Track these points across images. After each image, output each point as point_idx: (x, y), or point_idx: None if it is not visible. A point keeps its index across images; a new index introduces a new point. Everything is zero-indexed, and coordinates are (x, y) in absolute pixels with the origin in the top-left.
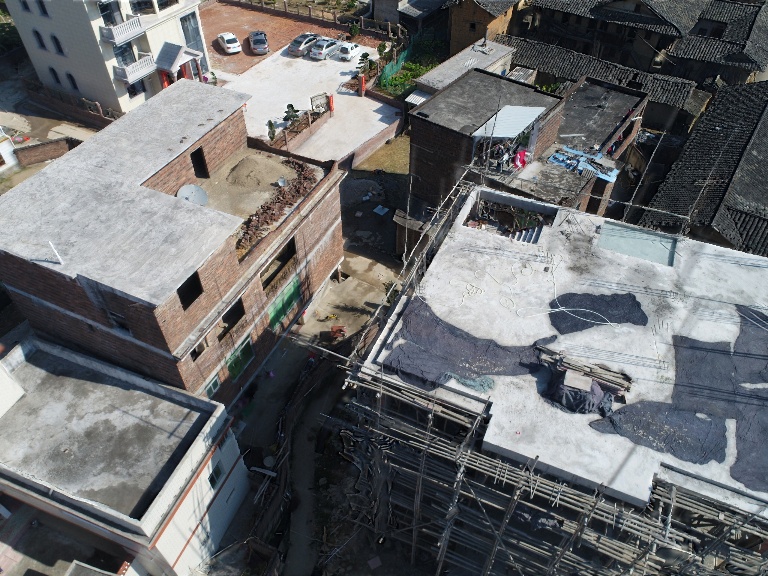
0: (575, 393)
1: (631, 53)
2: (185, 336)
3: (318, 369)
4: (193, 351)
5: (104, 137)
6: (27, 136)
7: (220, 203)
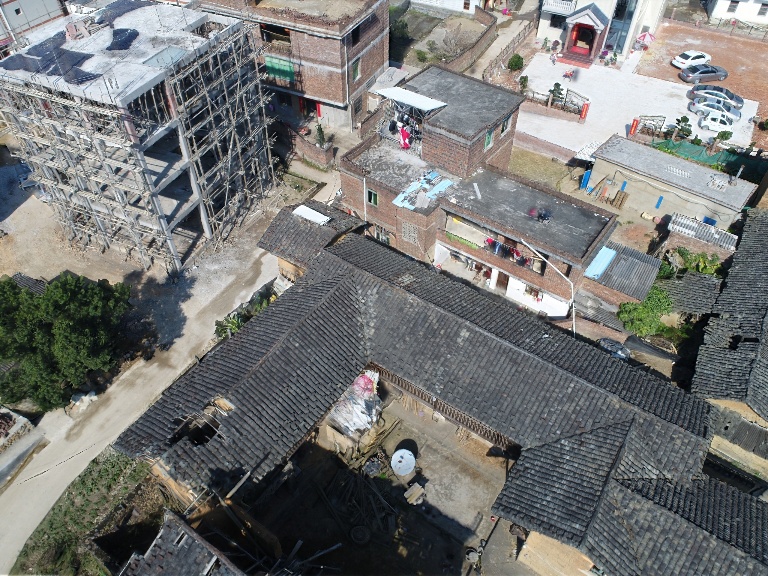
0: None
1: None
2: (208, 4)
3: None
4: None
5: None
6: (513, 15)
7: (310, 4)
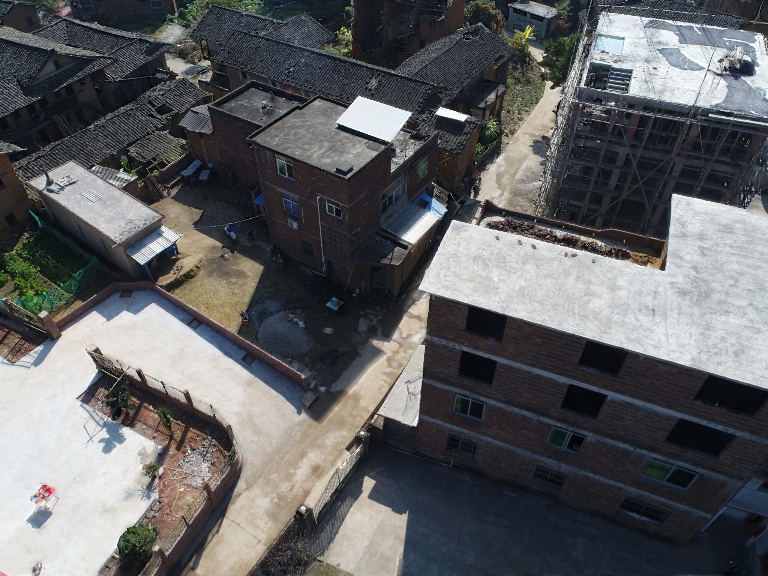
0: (752, 62)
1: (87, 104)
2: None
3: None
4: None
5: (594, 326)
6: None
7: None
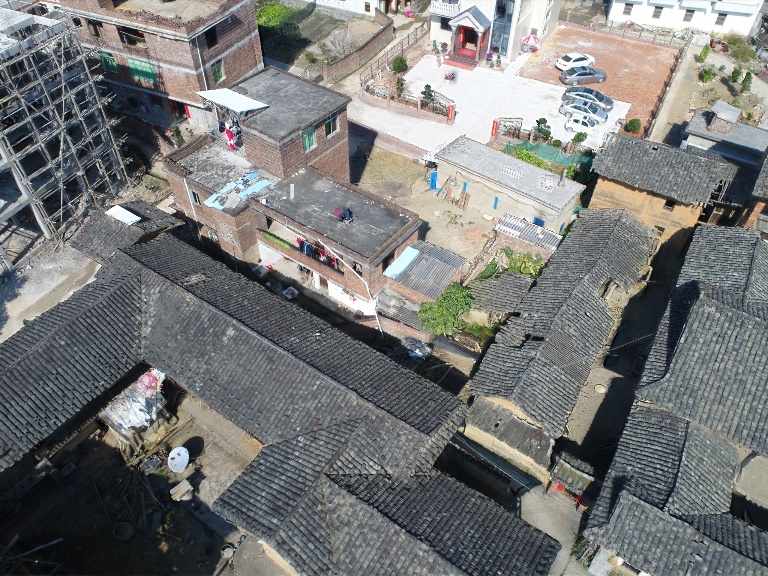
0: None
1: None
2: (68, 6)
3: (140, 123)
4: (75, 20)
5: None
6: (416, 17)
7: (169, 6)
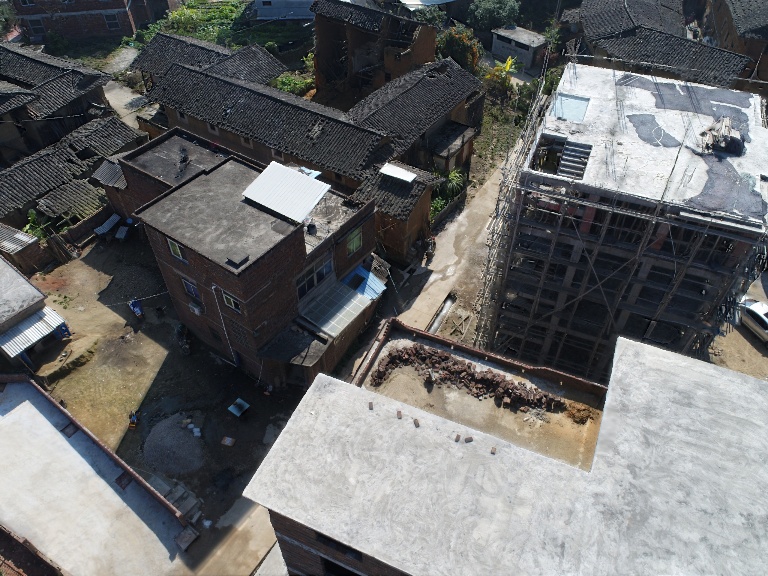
0: None
1: (5, 145)
2: None
3: None
4: None
5: (473, 575)
6: None
7: None
